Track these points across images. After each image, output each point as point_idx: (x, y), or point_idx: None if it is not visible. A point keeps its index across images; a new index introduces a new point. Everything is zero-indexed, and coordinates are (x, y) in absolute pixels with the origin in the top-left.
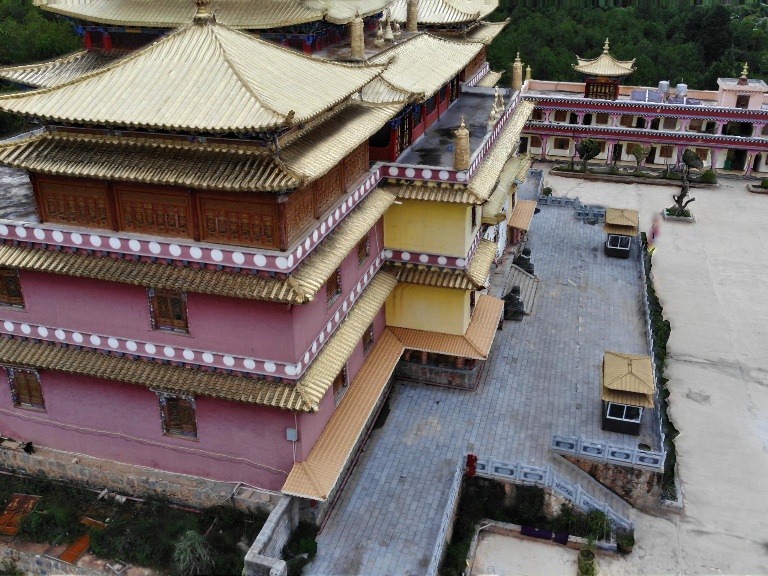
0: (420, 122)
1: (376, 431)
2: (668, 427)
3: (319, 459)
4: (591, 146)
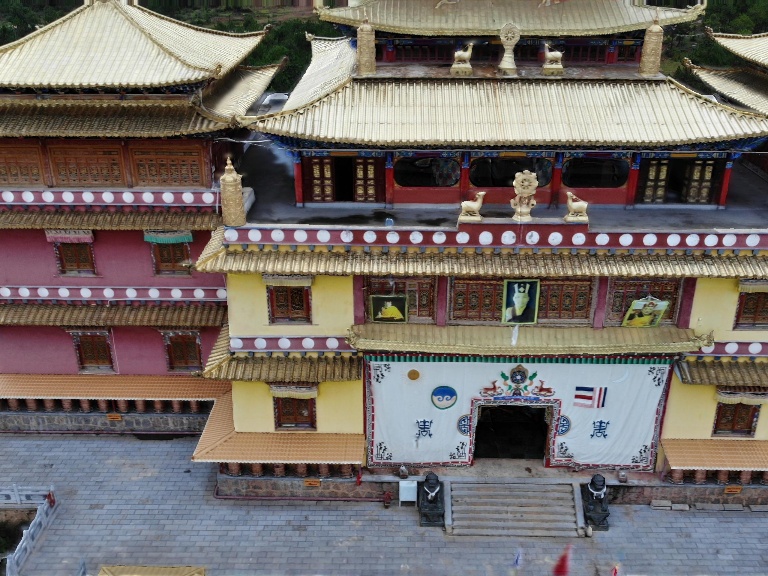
0: (445, 186)
1: (132, 437)
2: None
3: (4, 380)
4: None
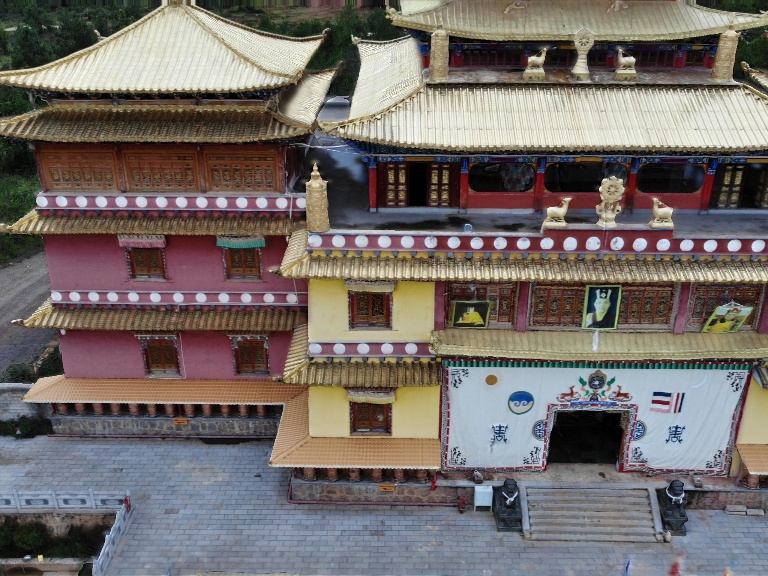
0: (519, 191)
1: (198, 441)
2: None
3: (71, 385)
4: None
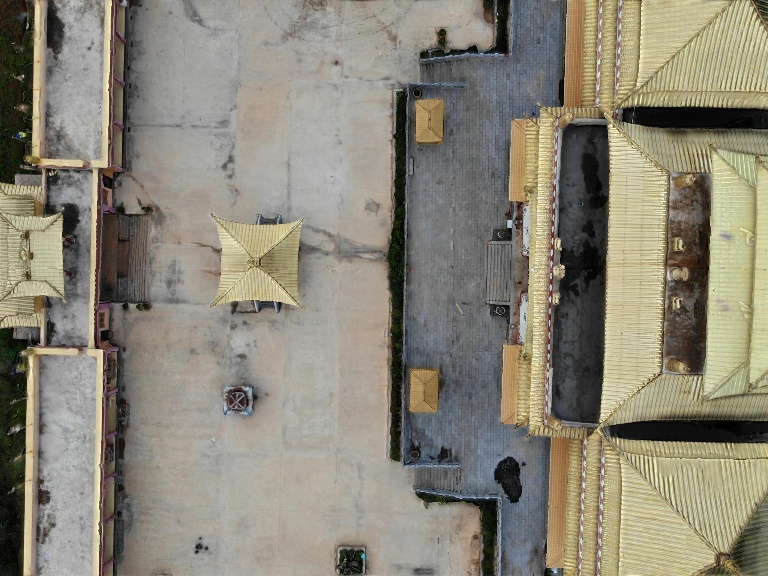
0: None
1: (562, 77)
2: (400, 132)
3: None
4: None
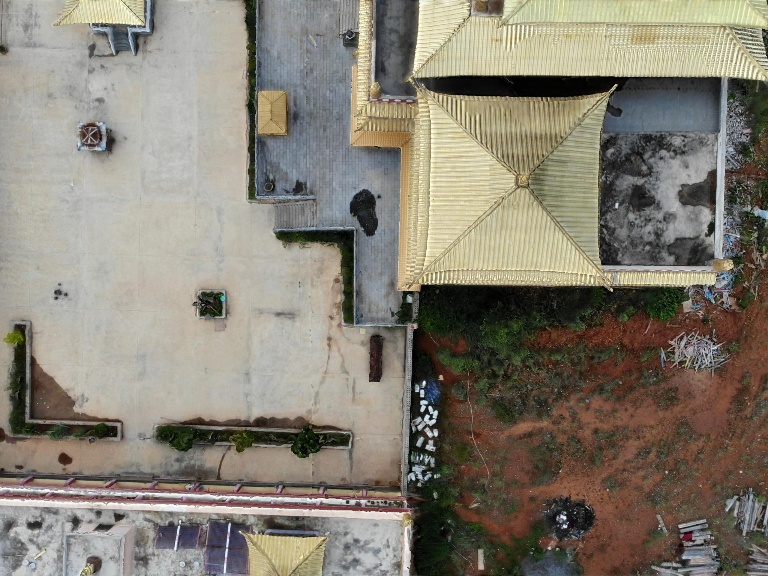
0: None
1: None
2: None
3: None
4: (303, 434)
